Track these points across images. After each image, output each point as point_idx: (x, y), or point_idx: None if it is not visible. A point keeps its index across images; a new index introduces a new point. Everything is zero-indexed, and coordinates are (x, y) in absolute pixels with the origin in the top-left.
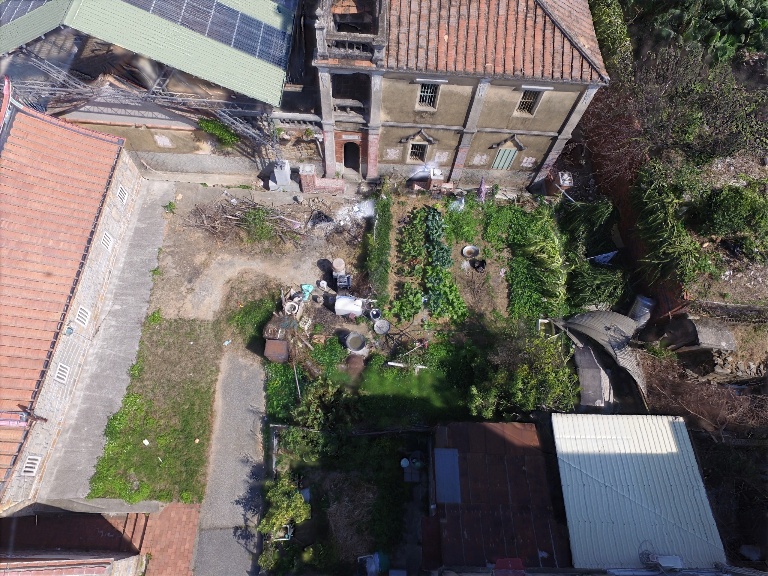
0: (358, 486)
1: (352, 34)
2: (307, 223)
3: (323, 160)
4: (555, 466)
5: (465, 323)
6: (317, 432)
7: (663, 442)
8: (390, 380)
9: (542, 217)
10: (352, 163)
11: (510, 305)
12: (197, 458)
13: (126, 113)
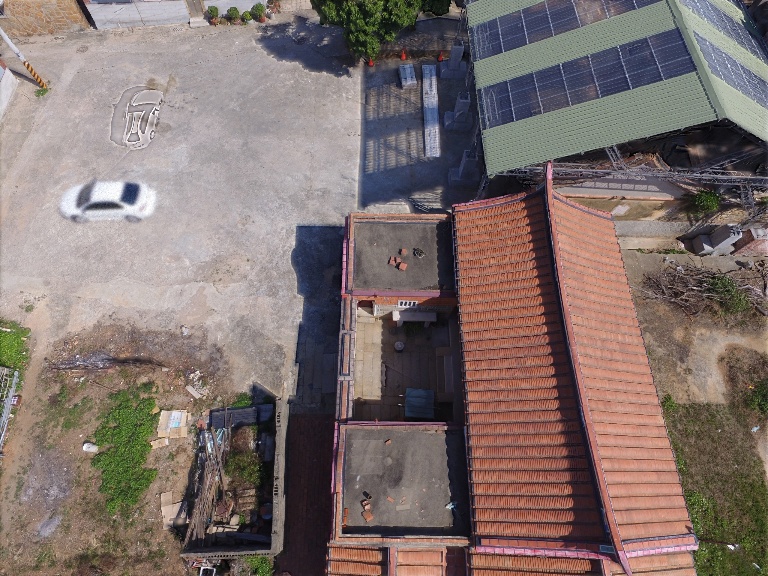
0: None
1: None
2: (765, 290)
3: None
4: None
5: None
6: None
7: None
8: None
9: None
10: None
11: None
12: None
13: (618, 187)
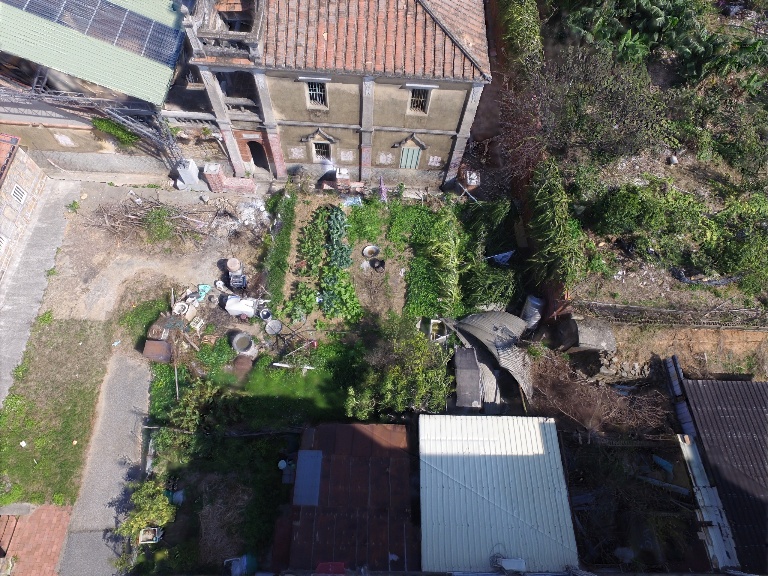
0: (233, 488)
1: (224, 32)
2: (211, 223)
3: (229, 159)
4: (416, 468)
5: (359, 323)
6: (191, 434)
7: (530, 444)
8: (276, 381)
9: (446, 216)
10: (264, 162)
11: (406, 305)
12: (73, 460)
13: (19, 112)
